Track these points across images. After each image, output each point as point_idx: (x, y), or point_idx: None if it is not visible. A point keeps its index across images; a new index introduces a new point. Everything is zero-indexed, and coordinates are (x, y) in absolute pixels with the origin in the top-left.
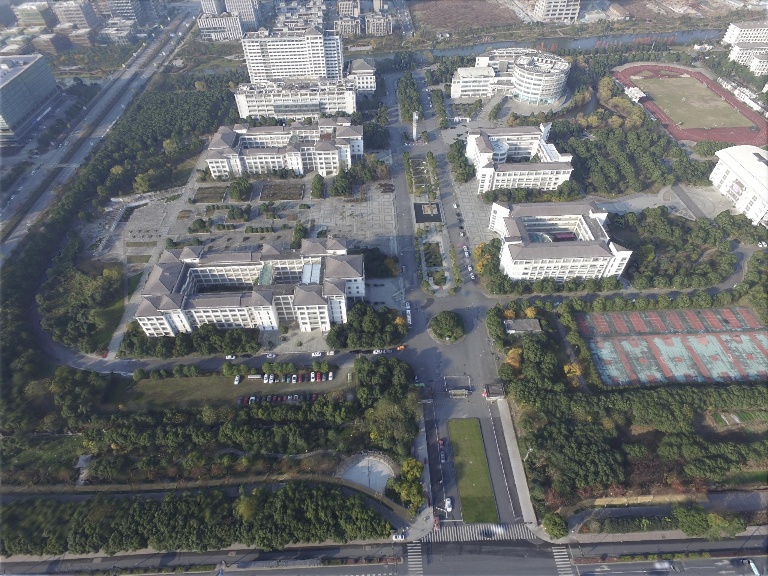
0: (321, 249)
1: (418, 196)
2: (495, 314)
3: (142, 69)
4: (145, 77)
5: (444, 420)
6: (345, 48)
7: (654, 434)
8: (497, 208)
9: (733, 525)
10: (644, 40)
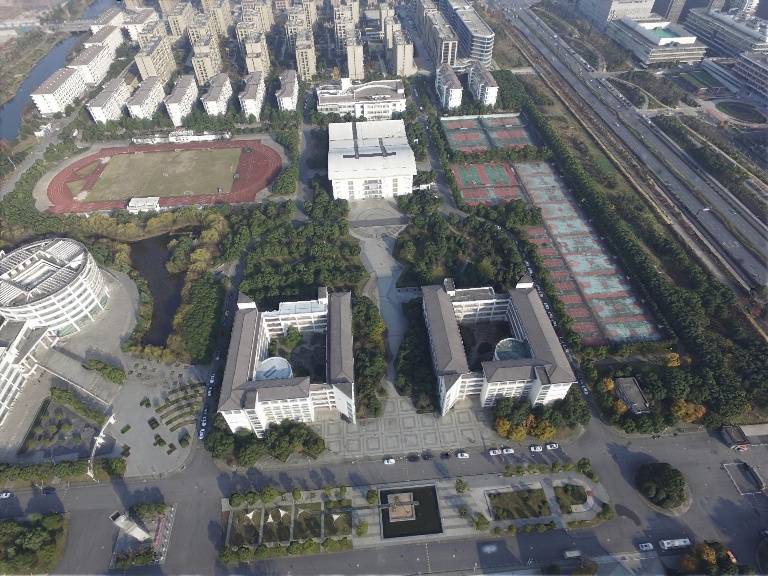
0: None
1: None
2: None
3: None
4: None
5: None
6: None
7: None
8: None
9: (764, 292)
10: None
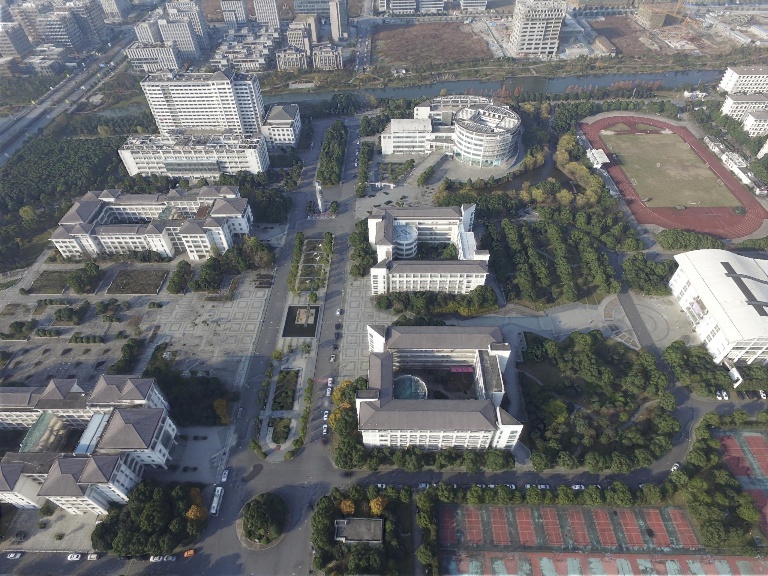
0: (116, 395)
1: (297, 295)
2: (326, 507)
3: (54, 106)
4: (49, 117)
5: None
6: (285, 85)
7: None
8: (372, 332)
9: None
10: (625, 84)
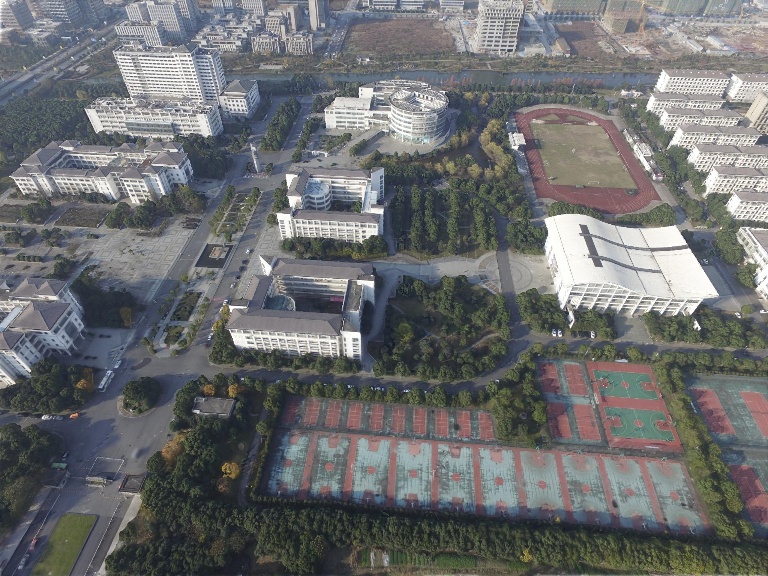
0: (34, 292)
1: (217, 236)
2: (191, 388)
3: (43, 73)
4: (36, 81)
5: (60, 513)
6: (256, 66)
7: (279, 566)
8: (263, 262)
9: None
10: (566, 80)
